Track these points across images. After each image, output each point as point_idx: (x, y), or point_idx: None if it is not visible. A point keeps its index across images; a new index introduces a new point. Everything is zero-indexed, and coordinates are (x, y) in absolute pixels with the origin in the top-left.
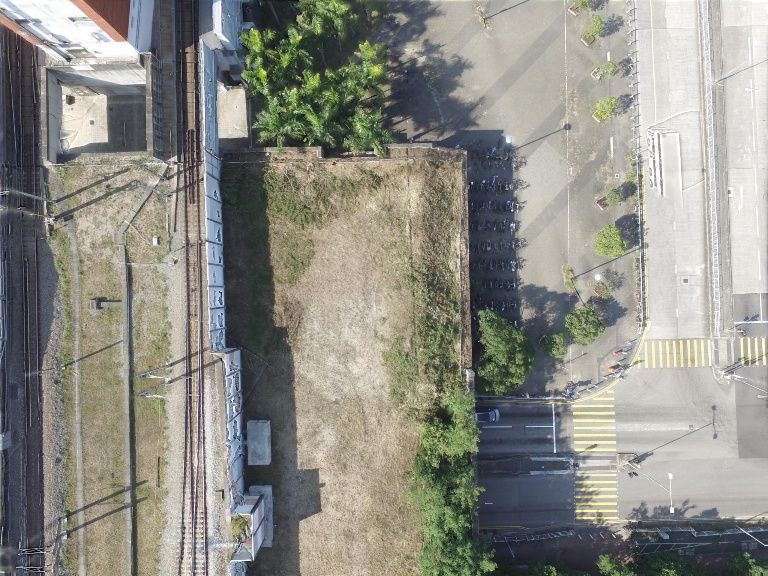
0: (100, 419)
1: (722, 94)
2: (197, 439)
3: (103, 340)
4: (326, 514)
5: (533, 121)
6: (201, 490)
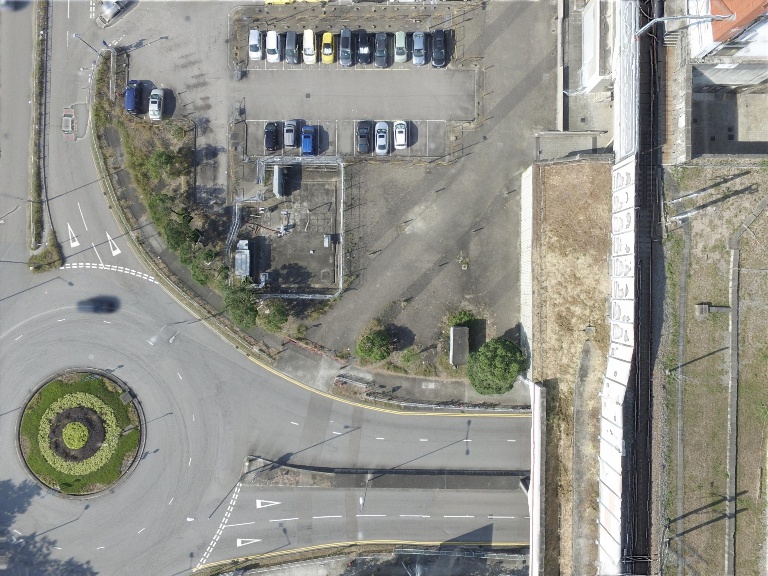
0: (701, 427)
1: None
2: None
3: (706, 346)
4: None
5: None
6: None
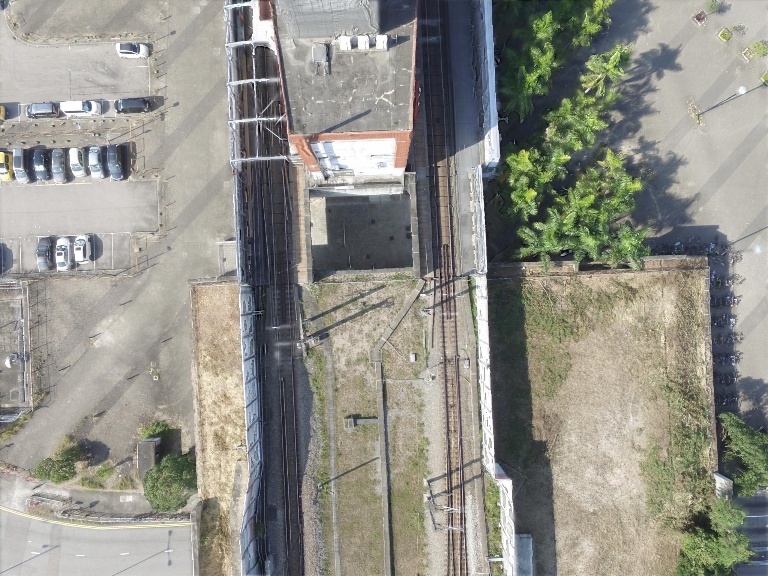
0: (357, 537)
1: None
2: (460, 556)
3: (358, 457)
4: None
5: (747, 216)
6: None
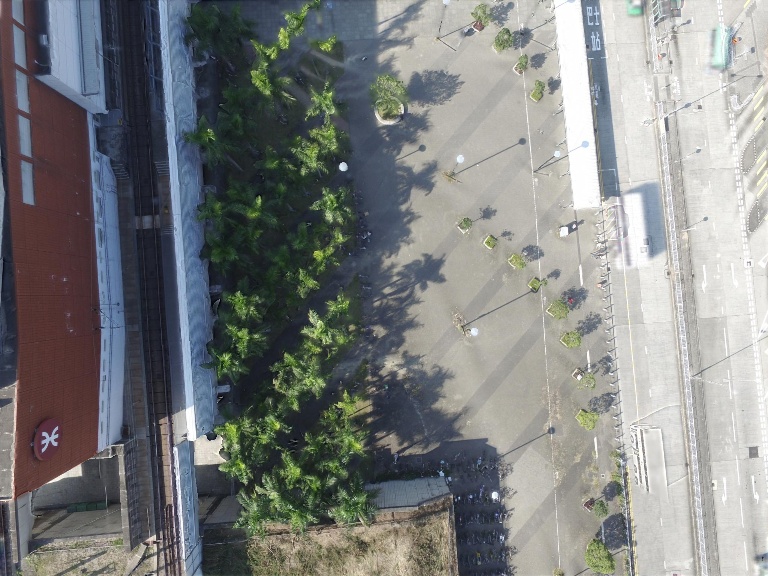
0: None
1: (701, 387)
2: None
3: None
4: None
5: (517, 427)
6: None
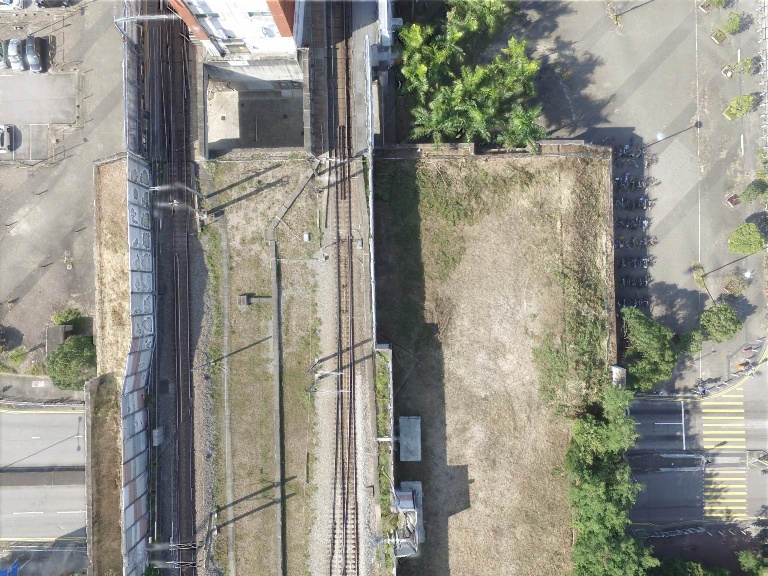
0: (249, 415)
1: None
2: (348, 435)
3: (252, 336)
4: (475, 510)
5: (664, 118)
6: (352, 486)
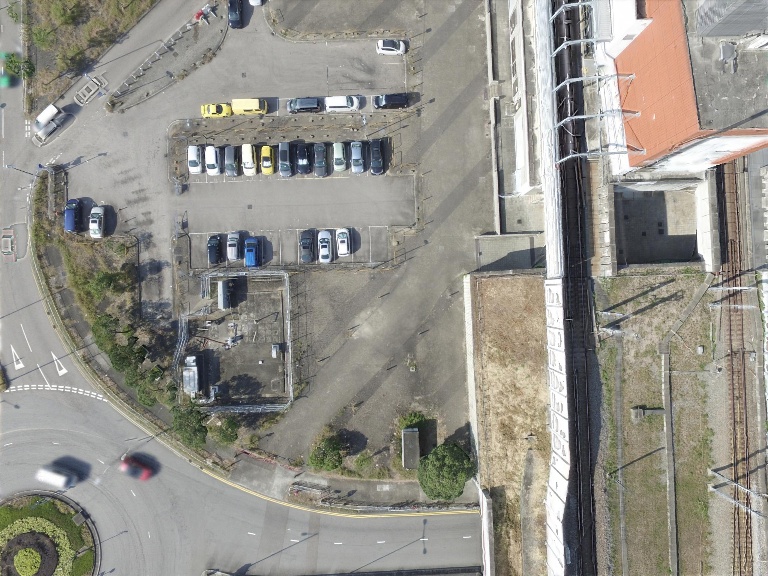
0: (643, 526)
1: None
2: (745, 544)
3: (643, 447)
4: None
5: None
6: None
